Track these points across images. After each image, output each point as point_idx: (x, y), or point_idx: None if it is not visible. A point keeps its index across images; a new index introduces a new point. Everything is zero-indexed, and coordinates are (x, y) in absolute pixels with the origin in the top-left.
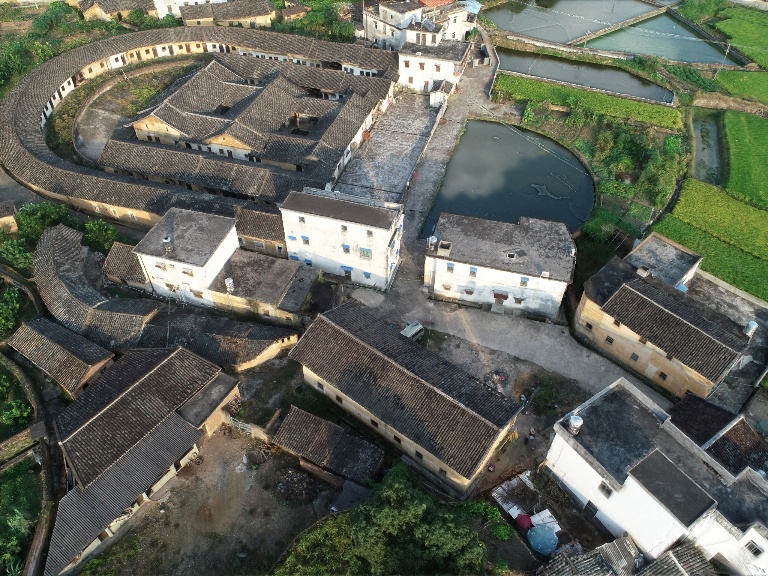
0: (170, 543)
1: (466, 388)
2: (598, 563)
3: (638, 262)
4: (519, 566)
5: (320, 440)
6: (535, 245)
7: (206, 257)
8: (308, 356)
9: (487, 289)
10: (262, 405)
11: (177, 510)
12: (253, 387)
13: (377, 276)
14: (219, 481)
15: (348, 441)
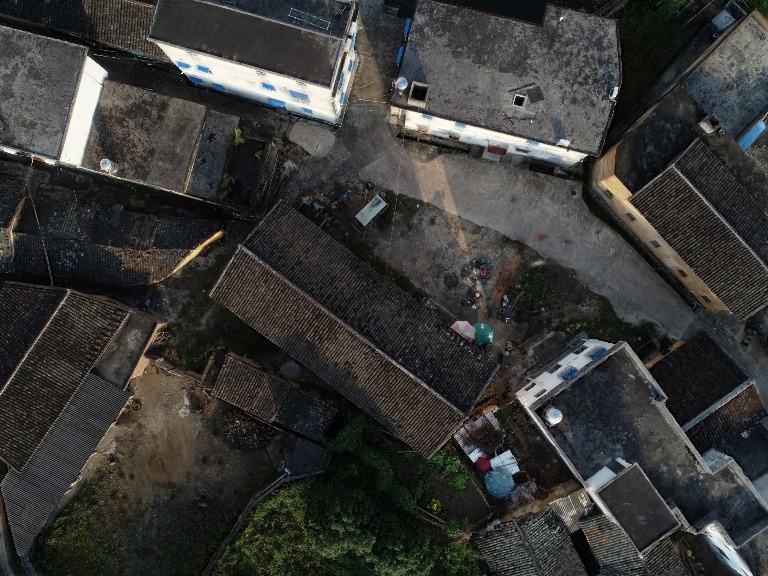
0: (130, 494)
1: (432, 349)
2: (548, 521)
3: (710, 77)
4: (472, 513)
5: (265, 395)
6: (559, 75)
7: (58, 139)
8: (235, 301)
9: (479, 137)
10: (194, 328)
11: (128, 461)
12: (178, 302)
13: (322, 113)
14: (164, 428)
15: (296, 397)
